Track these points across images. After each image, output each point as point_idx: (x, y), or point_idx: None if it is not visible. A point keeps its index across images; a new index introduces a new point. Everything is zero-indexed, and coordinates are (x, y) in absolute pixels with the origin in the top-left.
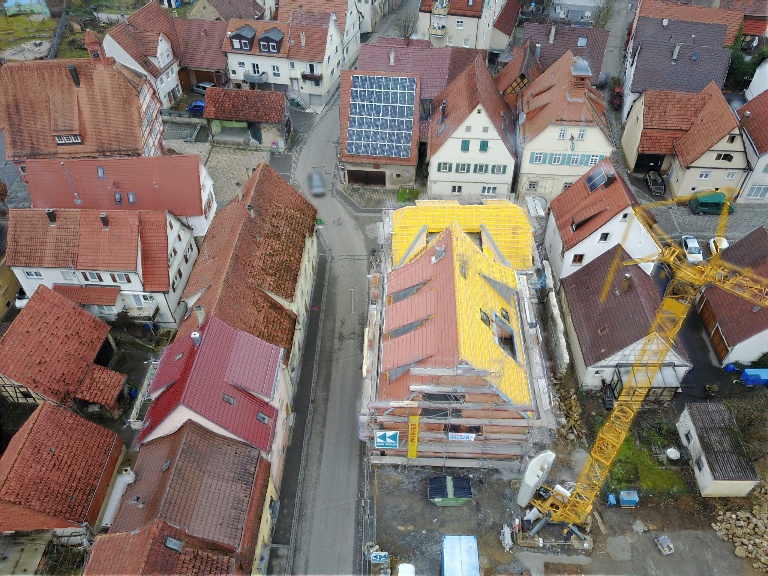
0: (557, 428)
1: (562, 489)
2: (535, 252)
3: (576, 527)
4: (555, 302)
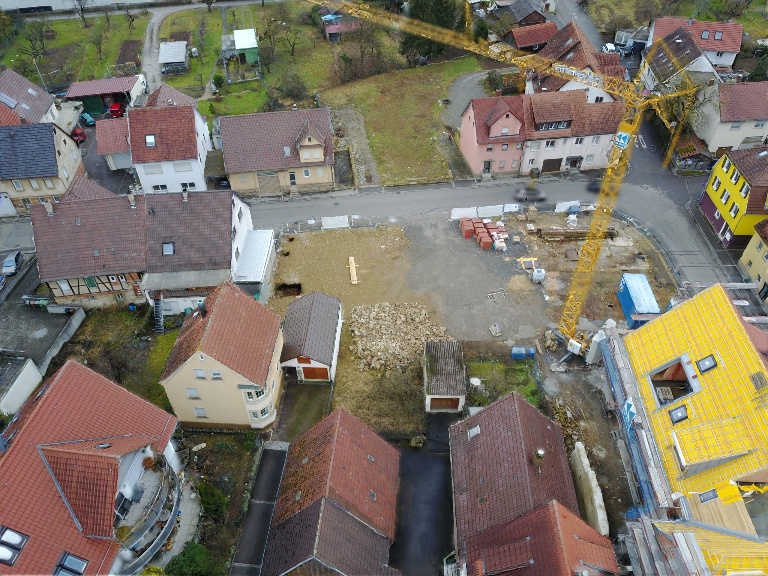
0: (573, 412)
1: (576, 344)
2: (655, 548)
3: (557, 343)
4: (601, 514)
